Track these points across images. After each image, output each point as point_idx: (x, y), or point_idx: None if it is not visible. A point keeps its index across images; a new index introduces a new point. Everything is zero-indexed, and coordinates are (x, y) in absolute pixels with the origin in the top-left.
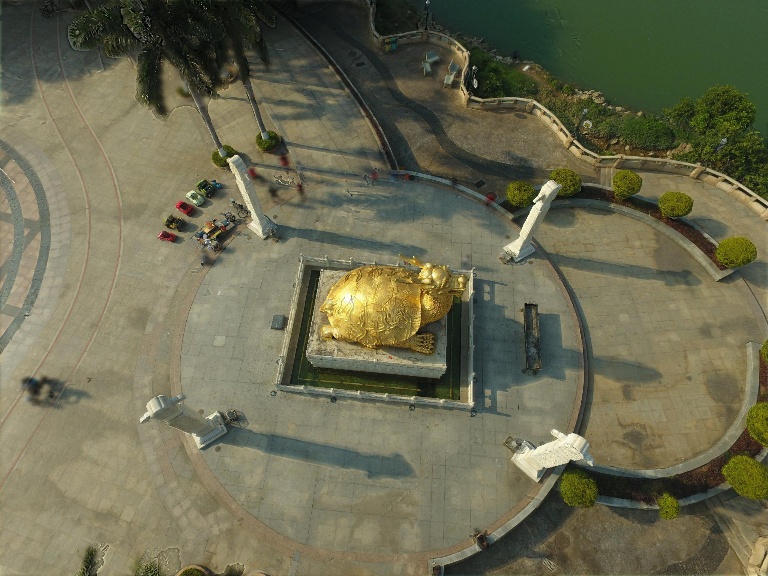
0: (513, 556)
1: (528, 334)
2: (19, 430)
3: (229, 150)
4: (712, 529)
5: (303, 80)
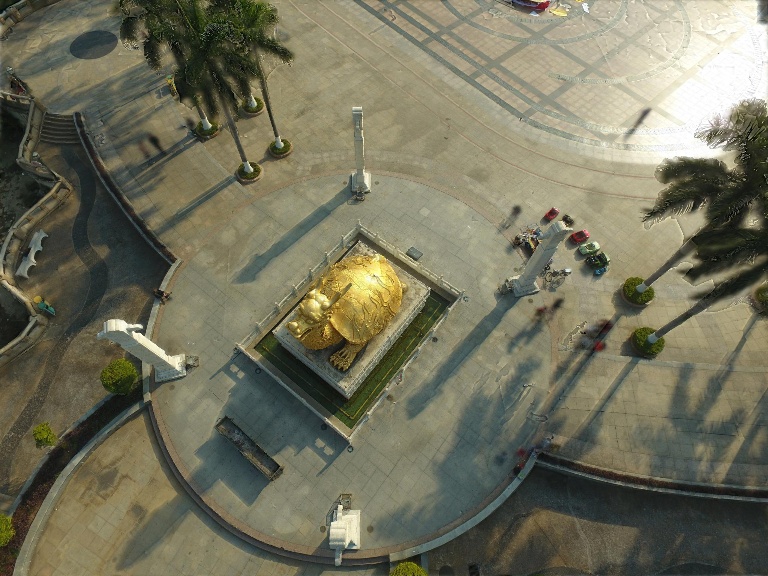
0: (141, 320)
1: (253, 446)
2: (434, 102)
3: (644, 296)
4: (8, 486)
5: (759, 437)
